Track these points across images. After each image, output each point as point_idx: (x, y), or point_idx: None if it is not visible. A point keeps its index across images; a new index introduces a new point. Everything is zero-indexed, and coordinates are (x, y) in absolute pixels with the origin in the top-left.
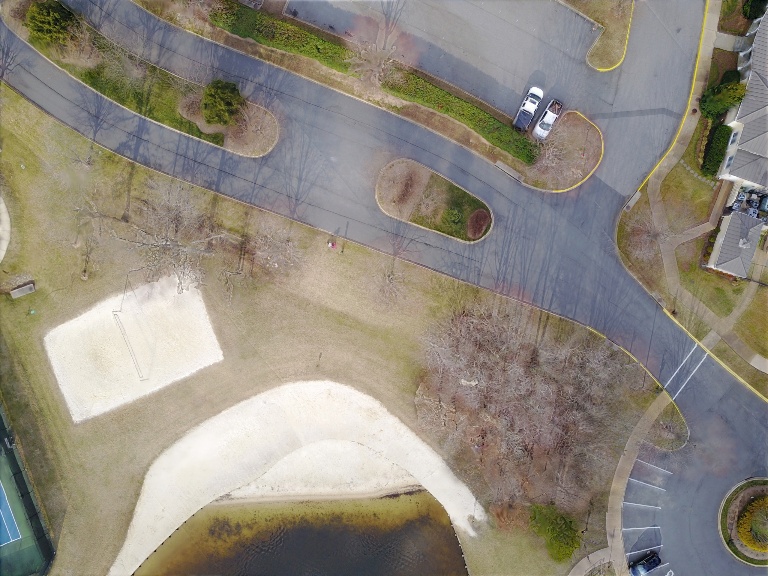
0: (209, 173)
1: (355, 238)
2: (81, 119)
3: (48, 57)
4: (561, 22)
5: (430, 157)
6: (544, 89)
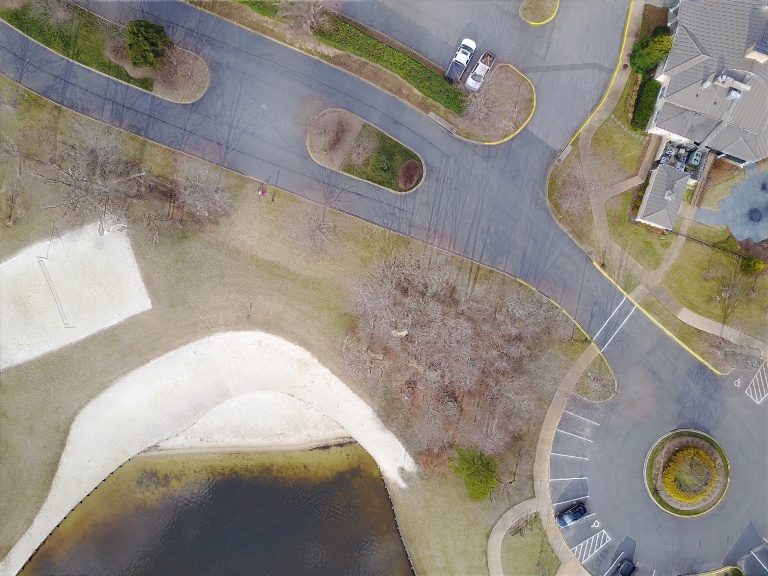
0: (138, 118)
1: (286, 187)
2: (7, 61)
3: None
4: None
5: (362, 107)
6: (477, 41)
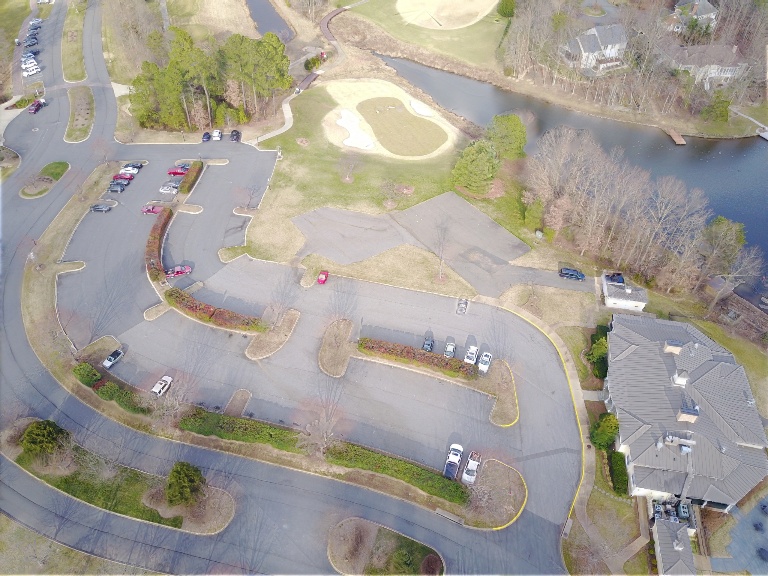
0: (164, 556)
1: None
2: (46, 521)
3: (30, 471)
4: (463, 397)
5: (375, 513)
6: (463, 446)
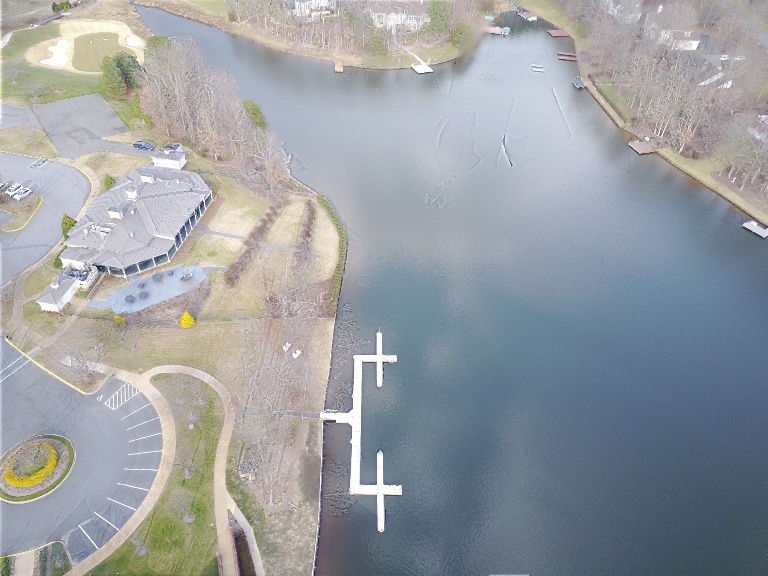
0: None
1: None
2: None
3: None
4: None
5: None
6: None
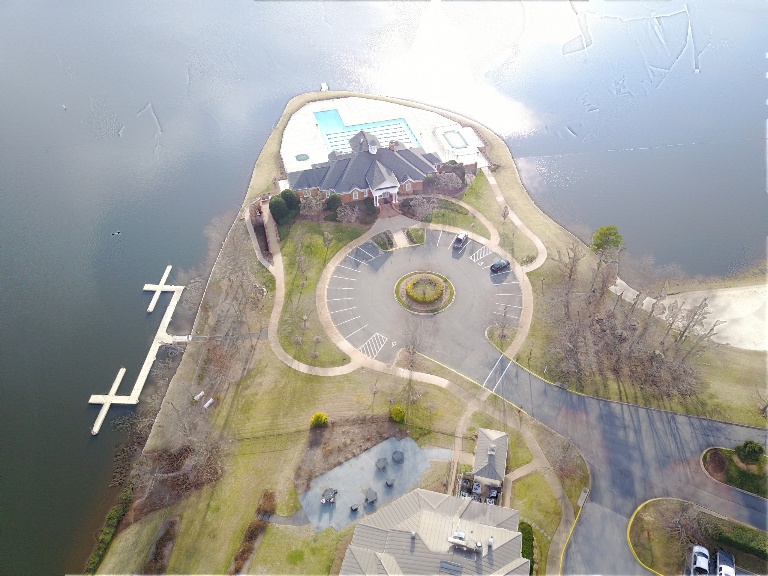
0: None
1: None
2: None
3: None
4: None
5: None
6: None
